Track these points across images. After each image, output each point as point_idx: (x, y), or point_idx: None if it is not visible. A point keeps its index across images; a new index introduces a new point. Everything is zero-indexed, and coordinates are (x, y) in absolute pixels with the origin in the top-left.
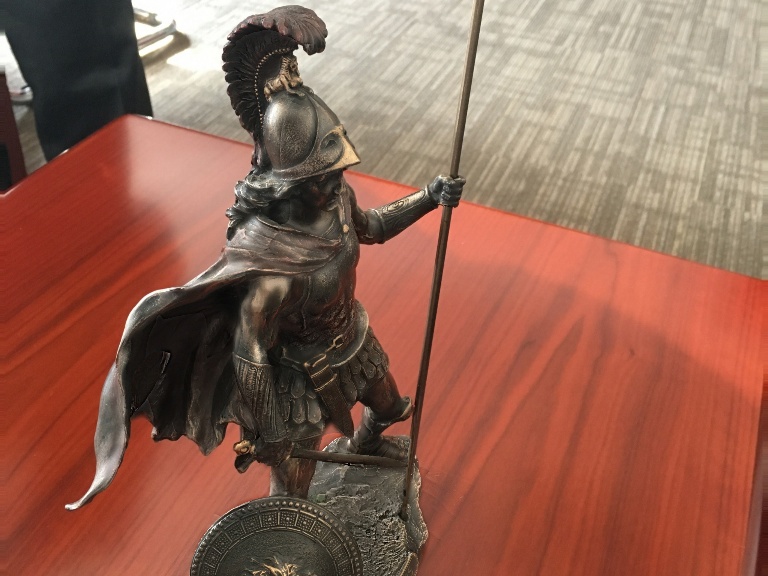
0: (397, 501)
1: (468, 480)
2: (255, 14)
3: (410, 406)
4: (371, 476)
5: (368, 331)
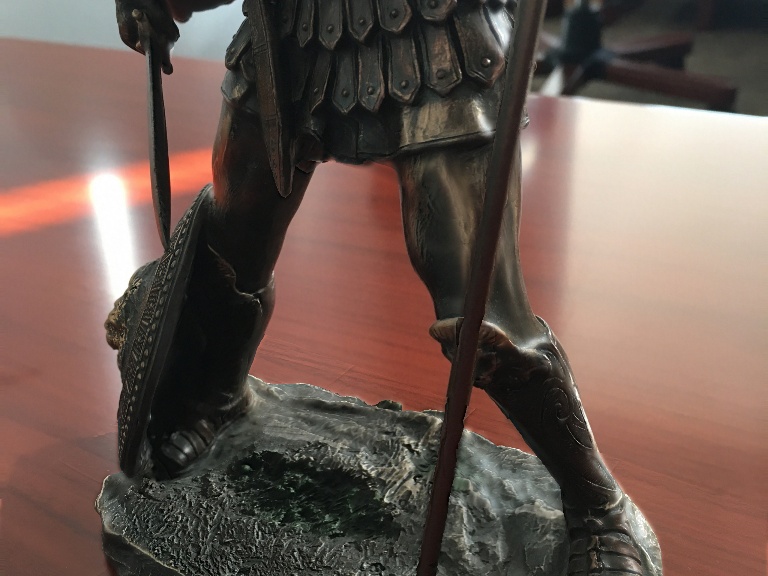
0: None
1: None
2: None
3: (451, 324)
4: (526, 561)
5: None
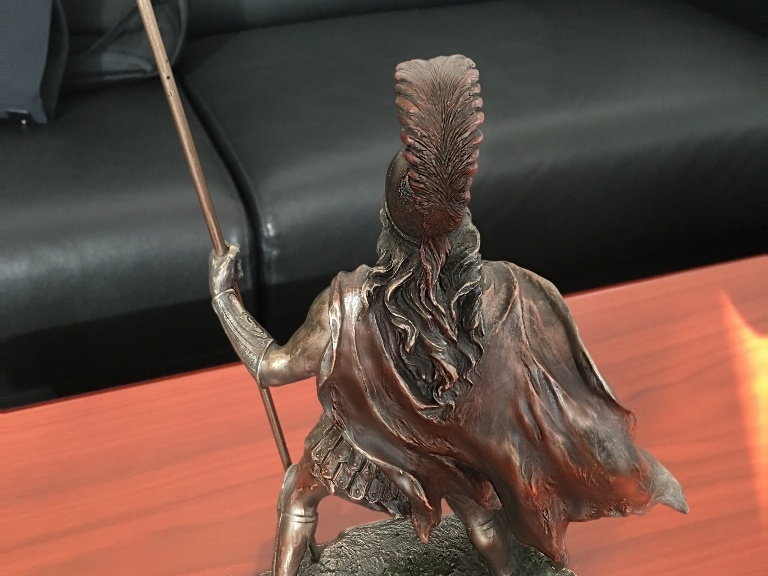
0: (304, 573)
1: (207, 574)
2: (463, 75)
3: None
4: None
5: None
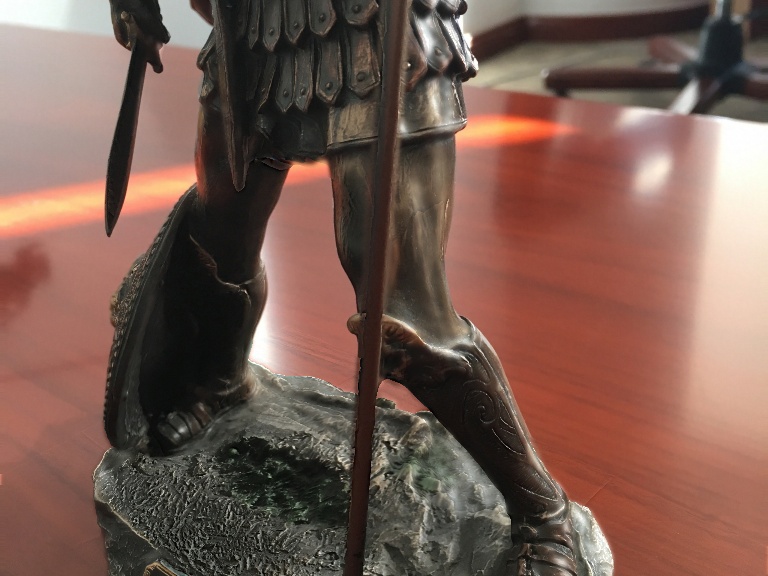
0: None
1: None
2: None
3: (361, 319)
4: (472, 564)
5: (353, 1)
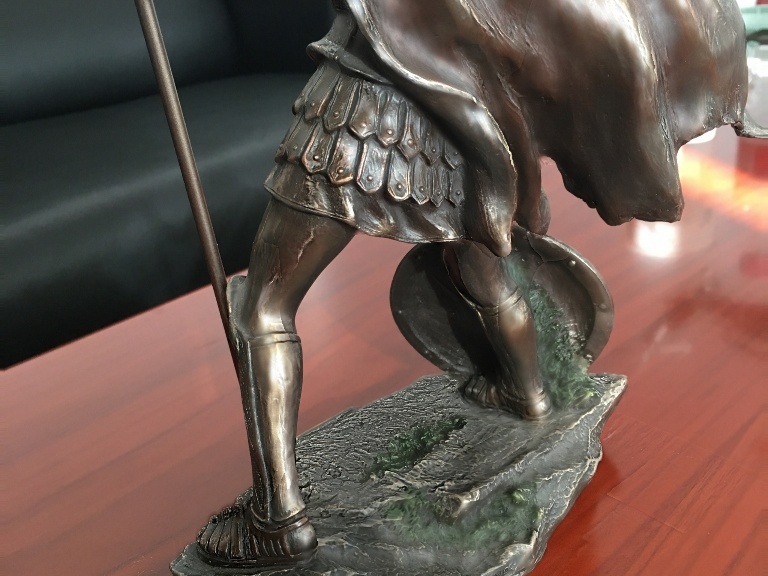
0: None
1: None
2: None
3: None
4: None
5: None
